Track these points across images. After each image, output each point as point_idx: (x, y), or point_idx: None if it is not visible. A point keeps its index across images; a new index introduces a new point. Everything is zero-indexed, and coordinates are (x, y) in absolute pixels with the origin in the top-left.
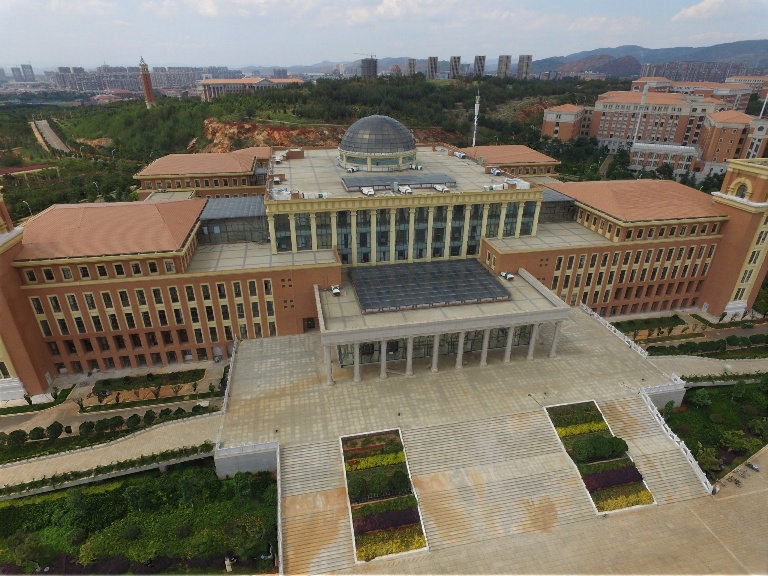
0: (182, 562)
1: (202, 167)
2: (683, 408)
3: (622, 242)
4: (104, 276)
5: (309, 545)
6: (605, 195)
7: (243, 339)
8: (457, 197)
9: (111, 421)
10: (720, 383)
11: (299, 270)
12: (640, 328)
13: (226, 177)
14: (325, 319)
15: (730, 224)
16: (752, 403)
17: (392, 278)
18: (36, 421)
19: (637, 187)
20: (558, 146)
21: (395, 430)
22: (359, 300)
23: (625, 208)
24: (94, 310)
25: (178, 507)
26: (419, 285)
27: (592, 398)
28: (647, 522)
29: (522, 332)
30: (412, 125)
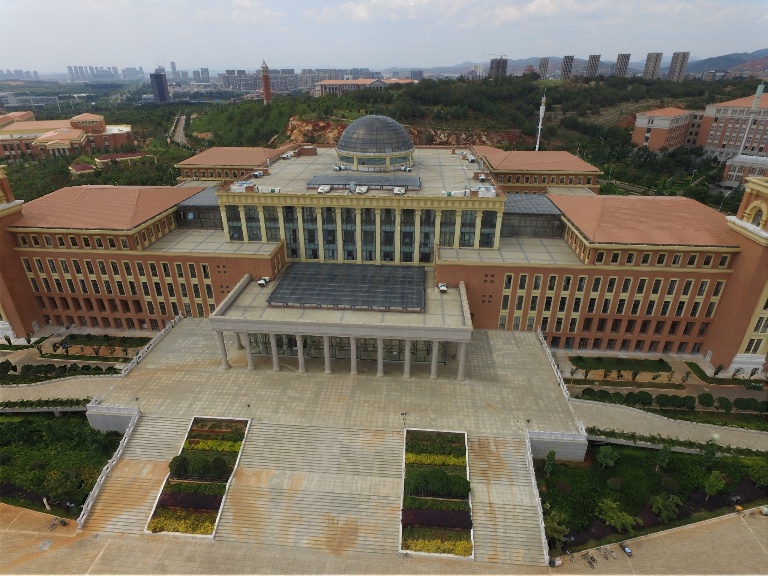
0: (22, 492)
1: (233, 160)
2: (586, 464)
3: (587, 265)
4: (76, 246)
5: (116, 505)
6: (593, 211)
7: (188, 316)
8: (405, 201)
9: (44, 367)
10: (646, 445)
11: (232, 258)
12: (606, 367)
13: (251, 170)
14: (231, 306)
15: (741, 257)
16: (682, 477)
17: (321, 276)
18: (8, 358)
19: (639, 204)
20: (645, 155)
21: (245, 420)
22: (271, 293)
23: (603, 227)
24: (68, 274)
25: (48, 447)
26: (340, 286)
27: (467, 430)
28: (449, 574)
29: (441, 349)
30: (488, 127)
